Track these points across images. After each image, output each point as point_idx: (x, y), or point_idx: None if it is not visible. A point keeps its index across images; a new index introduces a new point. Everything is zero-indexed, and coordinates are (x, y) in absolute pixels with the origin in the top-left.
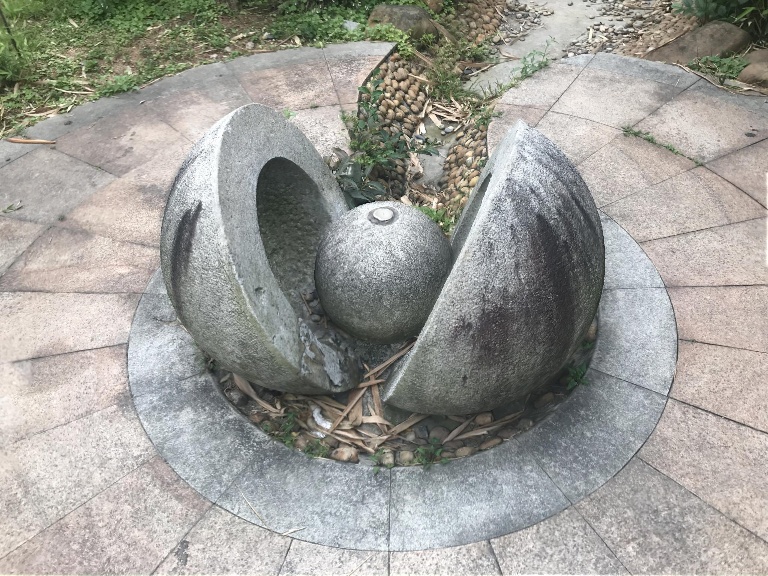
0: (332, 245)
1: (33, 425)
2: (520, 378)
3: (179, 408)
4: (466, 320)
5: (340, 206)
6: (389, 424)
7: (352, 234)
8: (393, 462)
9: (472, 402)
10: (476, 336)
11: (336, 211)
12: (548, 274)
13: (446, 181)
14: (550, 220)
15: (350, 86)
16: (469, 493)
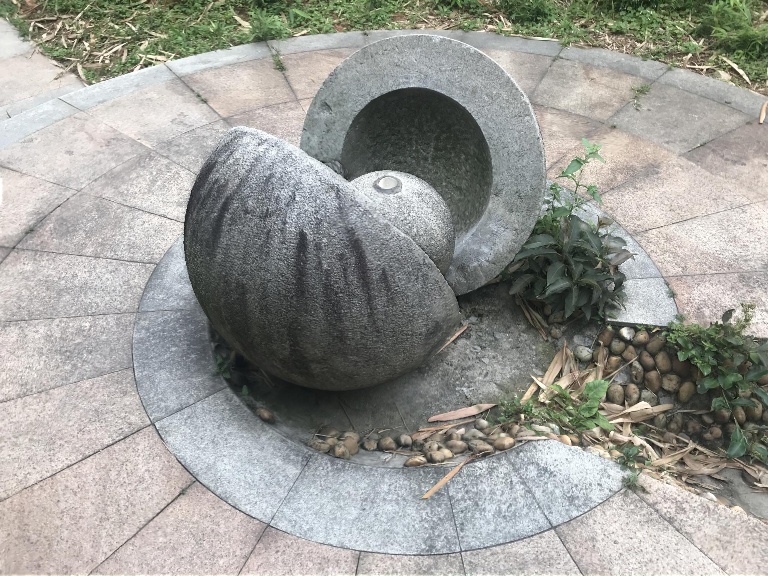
0: None
1: None
2: None
3: None
4: None
5: (502, 230)
6: None
7: None
8: None
9: None
10: None
11: (489, 222)
12: None
13: None
14: (212, 174)
15: None
16: None
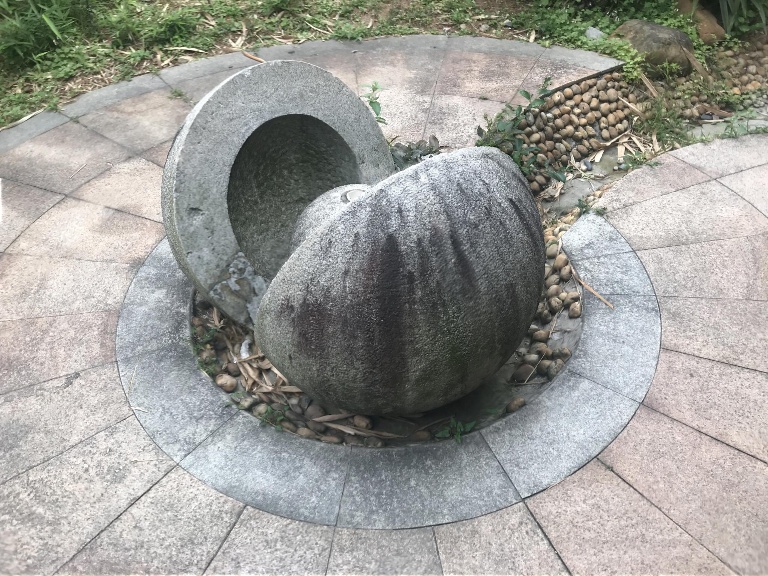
0: (308, 206)
1: (78, 252)
2: (343, 385)
3: (160, 287)
4: (290, 301)
5: None
6: (286, 381)
7: (321, 202)
8: (247, 406)
9: (307, 387)
10: (296, 321)
11: None
12: (377, 295)
13: (567, 213)
14: (403, 245)
15: (535, 90)
16: (271, 463)
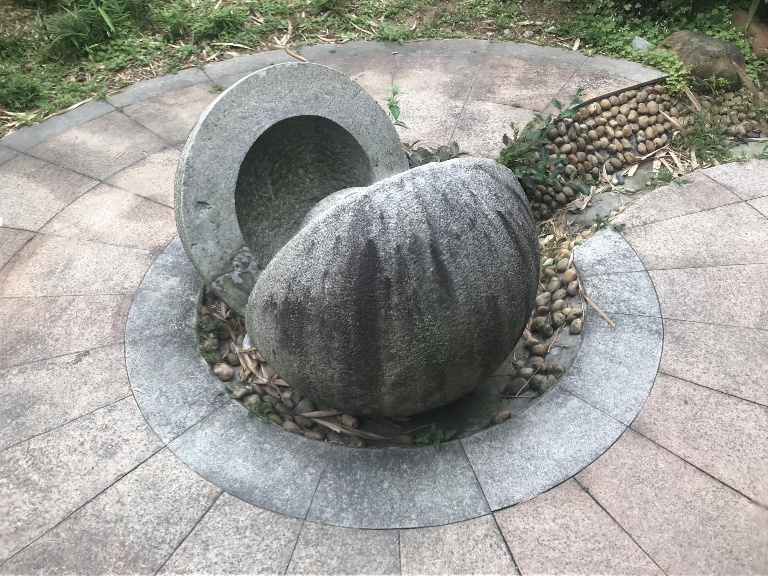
0: (314, 206)
1: (104, 236)
2: (322, 384)
3: (175, 274)
4: (274, 298)
5: None
6: None
7: (326, 203)
8: (239, 396)
9: (291, 382)
10: (278, 317)
11: None
12: (354, 298)
13: None
14: (381, 251)
15: None
16: (253, 453)
